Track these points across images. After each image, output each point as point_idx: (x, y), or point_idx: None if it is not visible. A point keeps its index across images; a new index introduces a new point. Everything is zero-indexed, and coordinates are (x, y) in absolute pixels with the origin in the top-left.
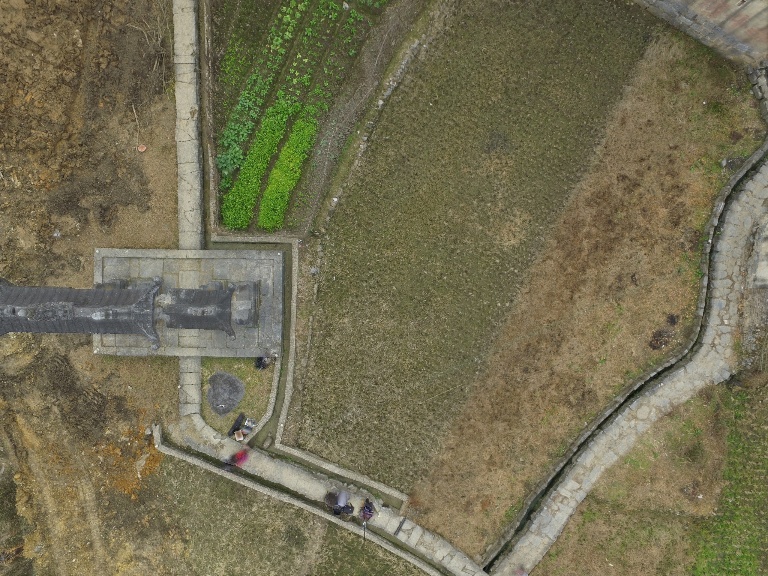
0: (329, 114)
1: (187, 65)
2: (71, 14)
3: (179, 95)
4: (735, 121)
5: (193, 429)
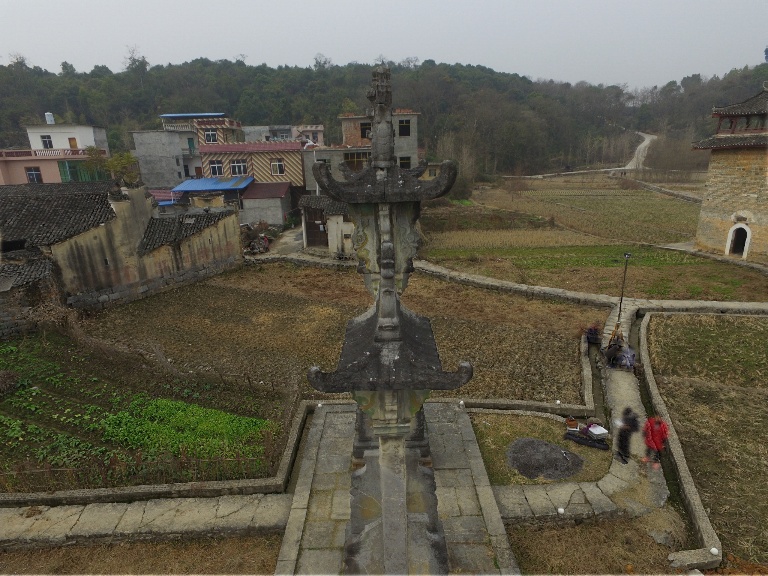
0: (153, 395)
1: None
2: None
3: None
4: (272, 267)
5: (631, 492)
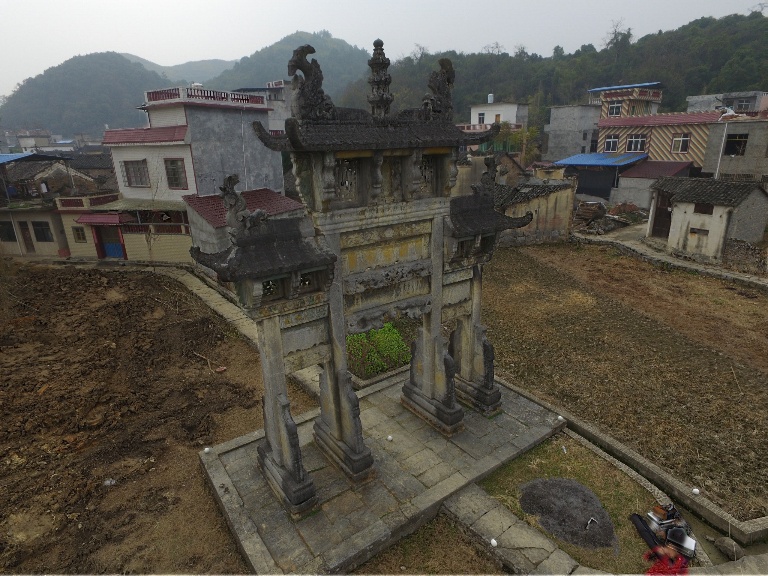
0: None
1: (242, 319)
2: (97, 338)
3: (245, 331)
4: None
5: None
